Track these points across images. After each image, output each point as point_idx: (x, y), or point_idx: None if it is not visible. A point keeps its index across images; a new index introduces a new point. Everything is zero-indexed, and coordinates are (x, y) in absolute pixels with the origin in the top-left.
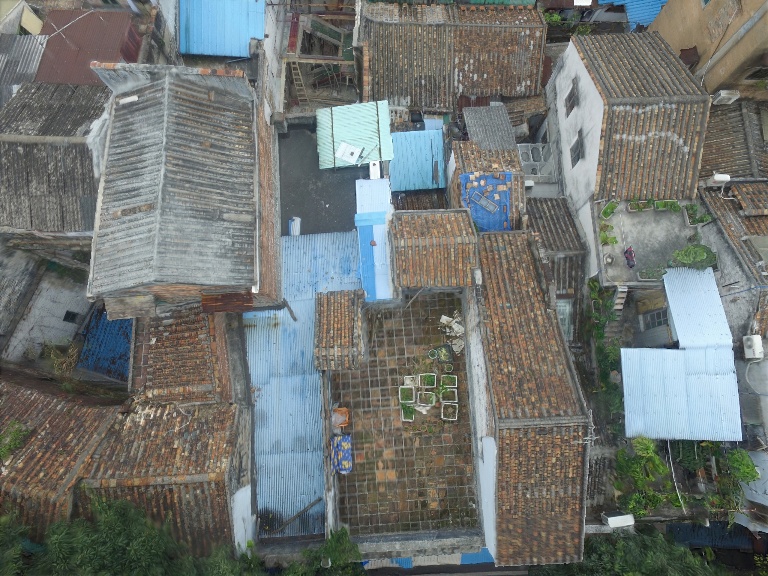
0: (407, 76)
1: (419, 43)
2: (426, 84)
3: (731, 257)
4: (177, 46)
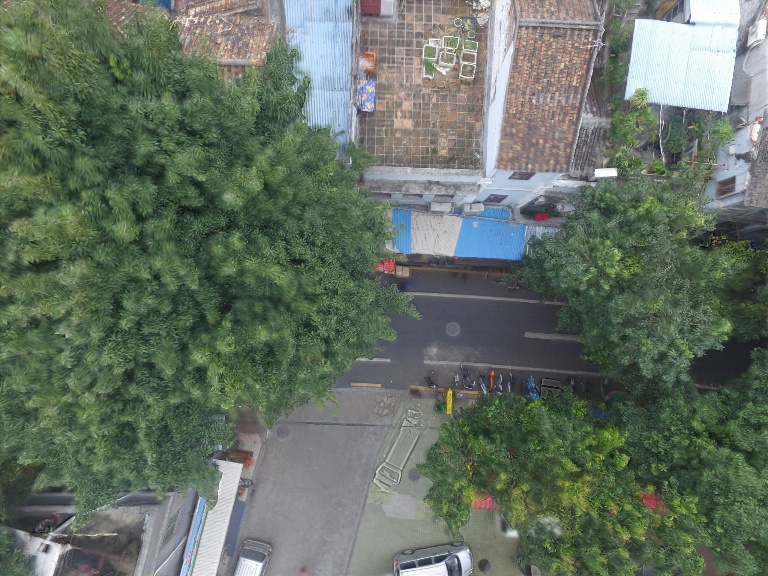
0: None
1: None
2: None
3: None
4: None
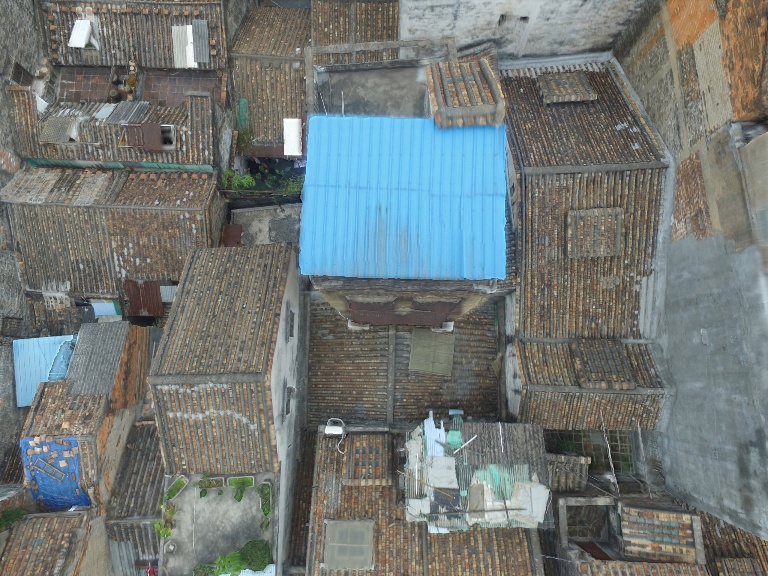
0: (62, 260)
1: (70, 225)
2: (85, 268)
3: None
4: None
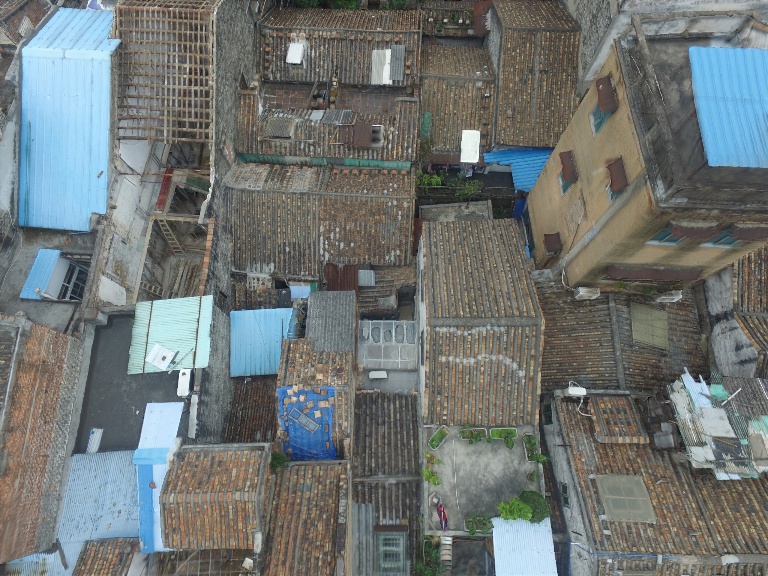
0: (270, 243)
1: (283, 210)
2: (290, 251)
3: (576, 500)
4: (14, 219)
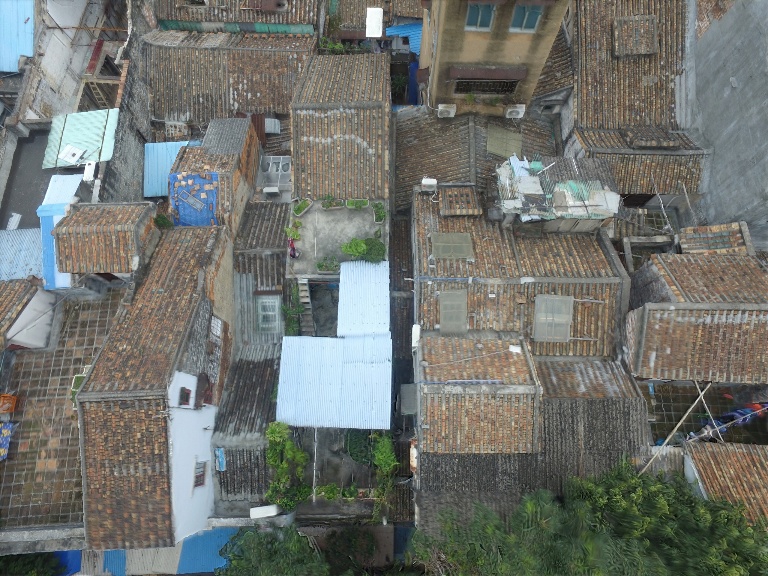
0: (186, 94)
1: (197, 65)
2: (204, 102)
3: None
4: None
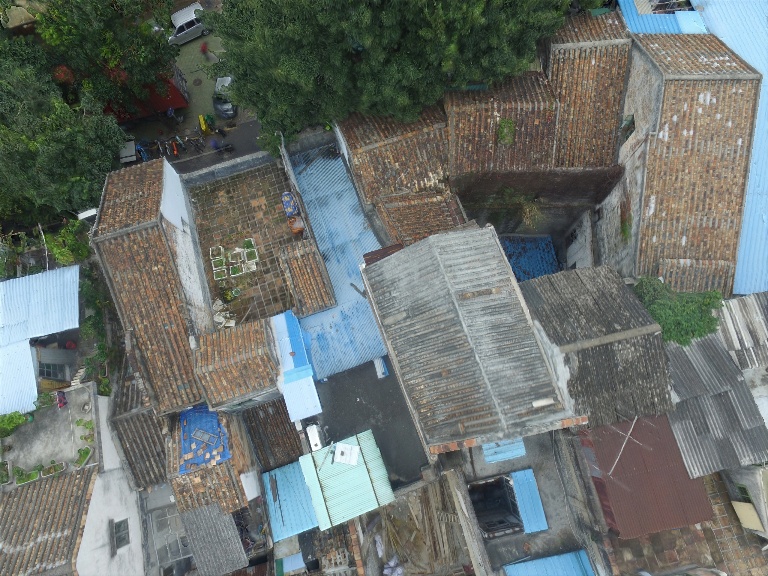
0: None
1: None
2: None
3: None
4: None
